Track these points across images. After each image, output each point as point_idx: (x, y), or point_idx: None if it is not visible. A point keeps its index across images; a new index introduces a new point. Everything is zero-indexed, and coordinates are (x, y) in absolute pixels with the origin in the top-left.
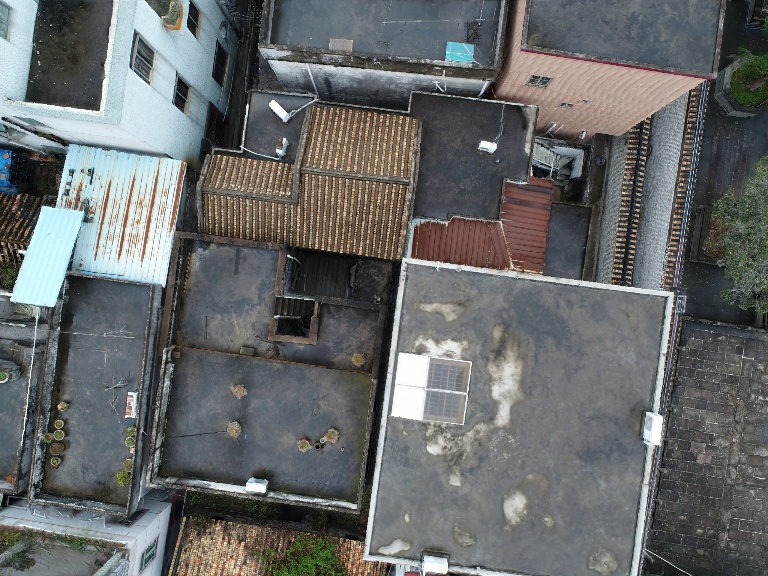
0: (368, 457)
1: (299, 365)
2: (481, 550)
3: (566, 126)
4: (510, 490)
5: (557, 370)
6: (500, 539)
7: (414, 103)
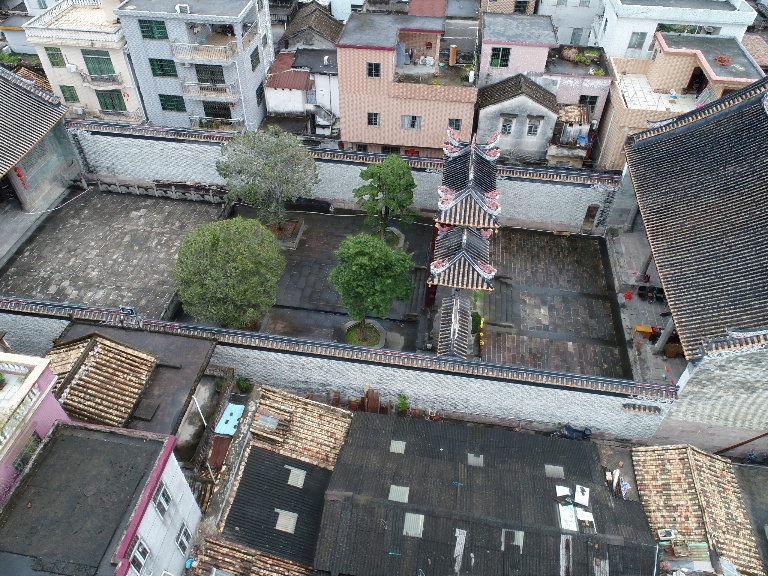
0: None
1: None
2: None
3: None
4: None
5: None
6: None
7: None
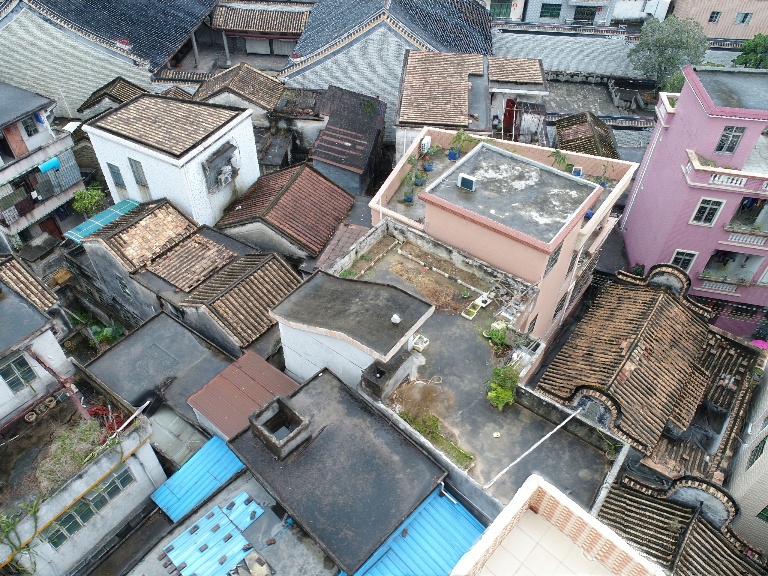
0: None
1: None
2: None
3: None
4: None
5: None
6: None
7: None
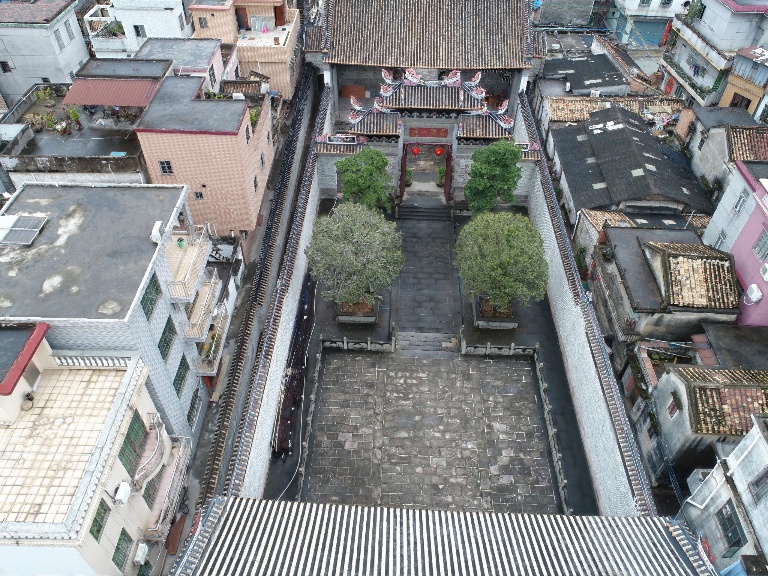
0: None
1: None
2: (16, 309)
3: (218, 227)
4: (52, 275)
5: (106, 220)
6: (33, 301)
7: None
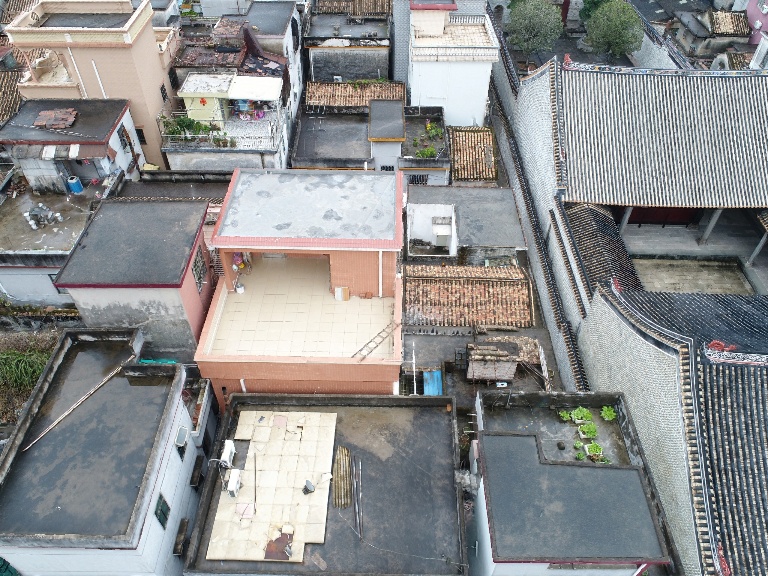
0: (390, 30)
1: (359, 25)
2: None
3: None
4: None
5: None
6: None
7: None
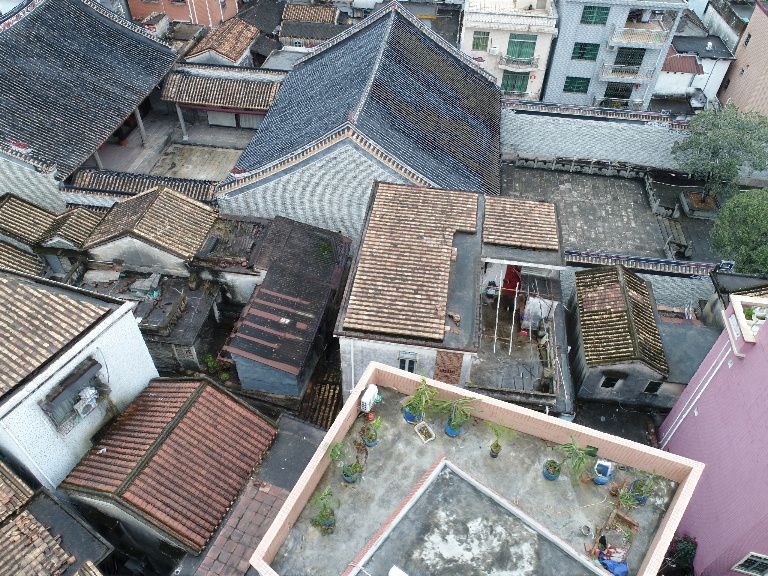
0: None
1: None
2: None
3: None
4: None
5: None
6: None
7: (714, 37)
